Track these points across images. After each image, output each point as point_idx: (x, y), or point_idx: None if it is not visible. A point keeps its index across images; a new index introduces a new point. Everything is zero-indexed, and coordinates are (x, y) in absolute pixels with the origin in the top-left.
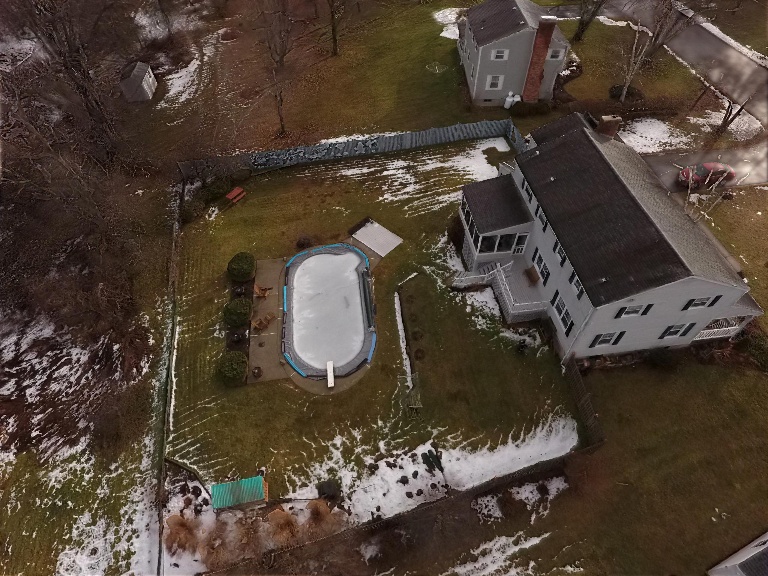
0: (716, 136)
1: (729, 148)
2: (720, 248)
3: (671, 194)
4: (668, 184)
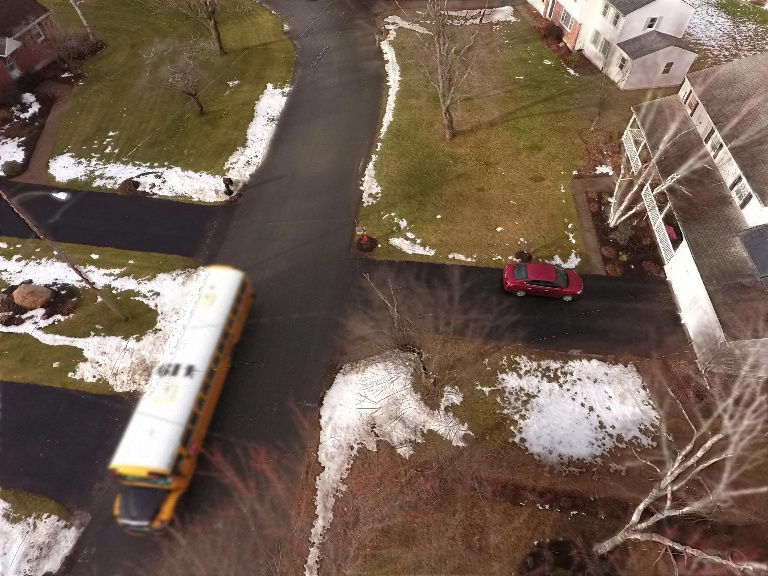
0: (449, 371)
1: (449, 338)
2: (580, 201)
3: (728, 143)
4: (596, 291)
